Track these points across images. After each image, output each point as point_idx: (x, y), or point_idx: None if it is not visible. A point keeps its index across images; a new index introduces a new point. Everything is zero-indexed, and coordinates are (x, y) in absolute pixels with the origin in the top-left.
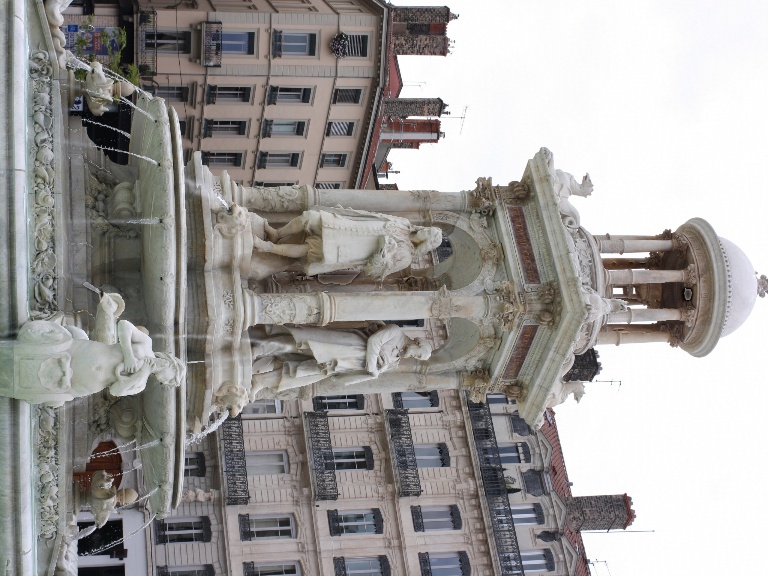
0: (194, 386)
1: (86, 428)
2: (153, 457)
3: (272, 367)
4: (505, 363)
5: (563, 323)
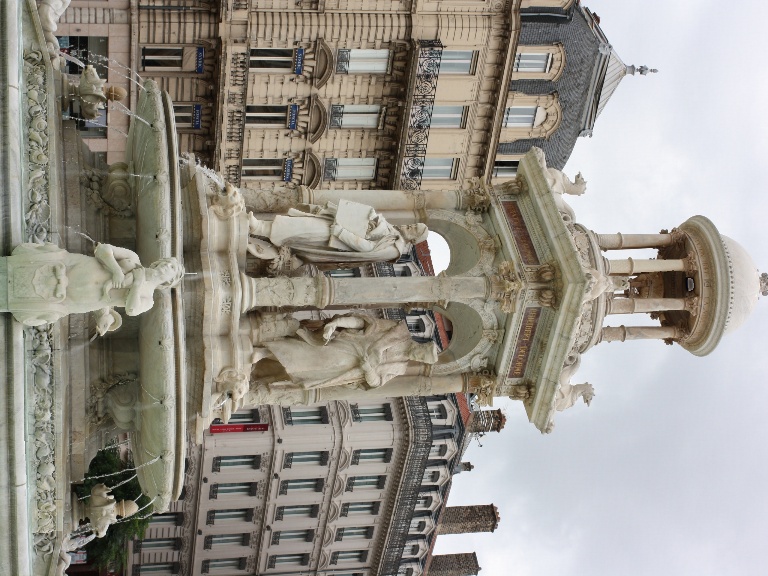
0: (185, 190)
1: (77, 170)
2: (140, 104)
3: (274, 252)
4: (514, 244)
5: (525, 169)
